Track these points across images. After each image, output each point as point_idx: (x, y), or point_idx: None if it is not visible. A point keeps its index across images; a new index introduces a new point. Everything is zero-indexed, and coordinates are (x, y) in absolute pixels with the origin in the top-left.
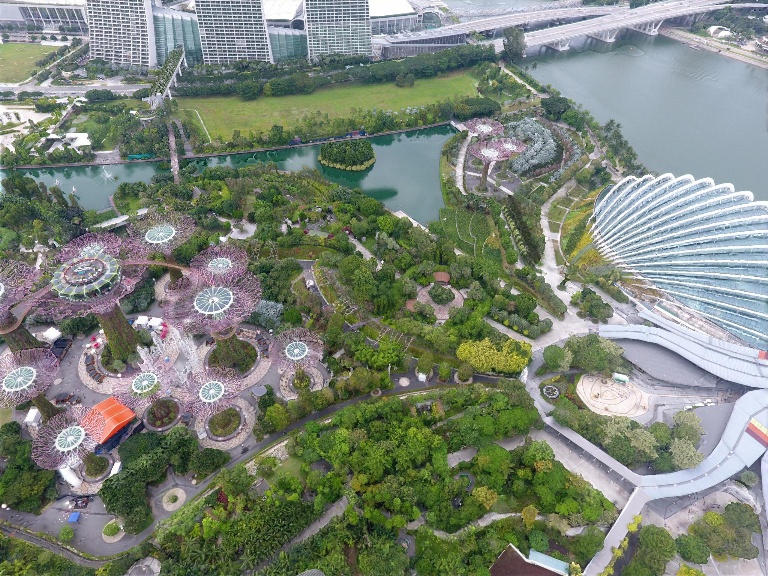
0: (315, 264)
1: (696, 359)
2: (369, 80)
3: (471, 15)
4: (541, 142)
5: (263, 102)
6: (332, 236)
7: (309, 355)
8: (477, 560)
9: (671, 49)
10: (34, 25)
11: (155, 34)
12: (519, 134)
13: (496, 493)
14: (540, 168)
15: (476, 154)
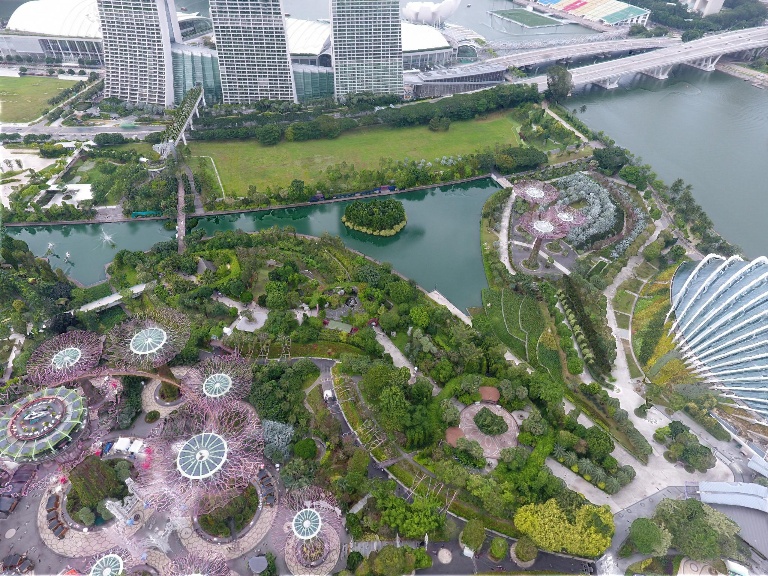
0: (335, 367)
1: None
2: (400, 123)
3: (509, 48)
4: (598, 206)
5: (284, 148)
6: (356, 329)
7: (323, 532)
8: None
9: (730, 86)
10: (54, 57)
11: (173, 71)
12: (571, 193)
13: None
14: (599, 239)
15: (527, 228)
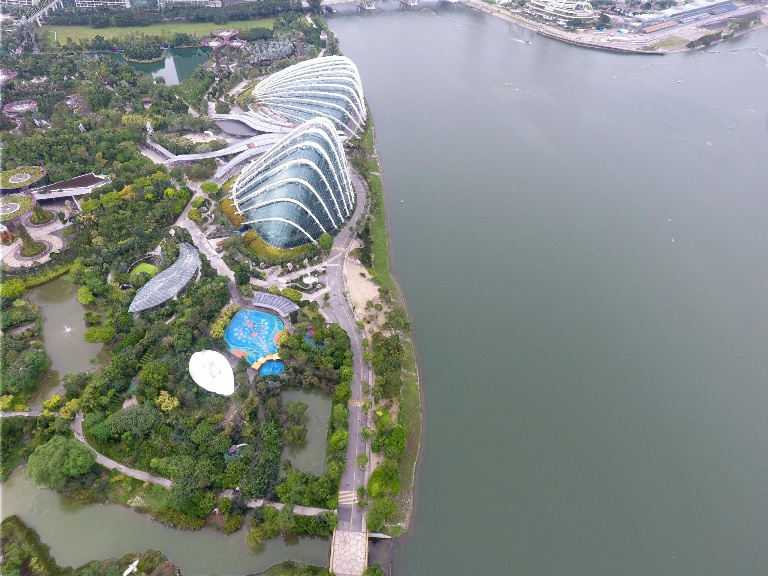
0: None
1: (252, 124)
2: (194, 19)
3: None
4: None
5: (108, 29)
6: None
7: None
8: (64, 168)
9: (466, 13)
10: None
11: None
12: None
13: (85, 148)
14: None
15: (204, 43)
